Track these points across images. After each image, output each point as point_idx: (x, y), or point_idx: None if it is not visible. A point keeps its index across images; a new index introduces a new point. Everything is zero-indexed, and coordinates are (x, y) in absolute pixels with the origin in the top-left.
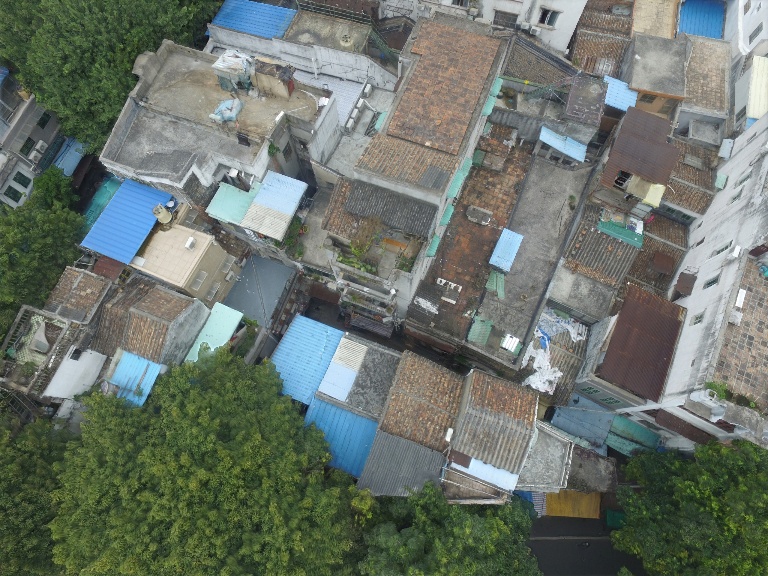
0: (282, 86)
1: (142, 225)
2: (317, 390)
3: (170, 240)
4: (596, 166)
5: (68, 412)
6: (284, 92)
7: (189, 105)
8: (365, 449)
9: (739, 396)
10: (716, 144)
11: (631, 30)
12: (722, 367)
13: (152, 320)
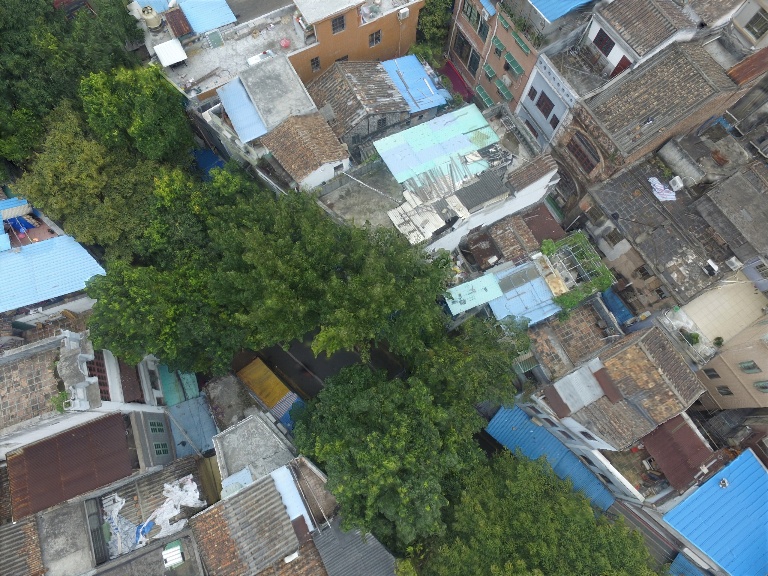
0: None
1: None
2: None
3: None
4: None
5: None
6: None
7: None
8: None
9: (56, 377)
10: None
11: None
12: (38, 405)
13: None
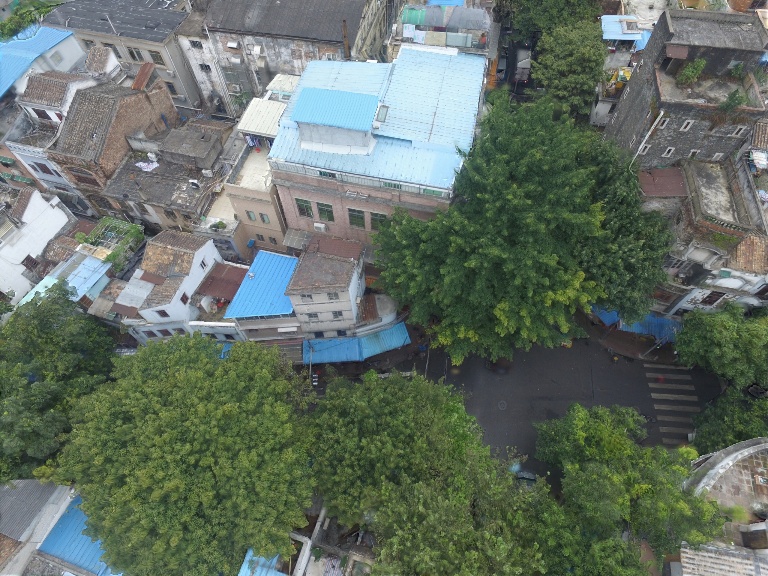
0: None
1: None
2: None
3: None
4: None
5: None
6: None
7: None
8: (63, 522)
9: None
10: None
11: None
12: None
13: None
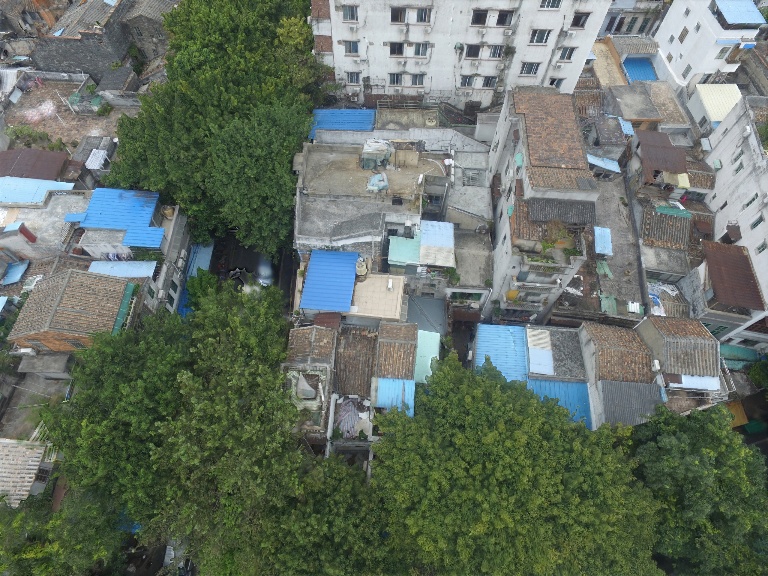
0: (416, 156)
1: (345, 280)
2: (529, 372)
3: (370, 287)
4: (626, 175)
5: (328, 454)
6: (415, 161)
7: (343, 185)
8: (585, 407)
9: None
10: (691, 145)
11: (600, 85)
12: None
13: (400, 344)
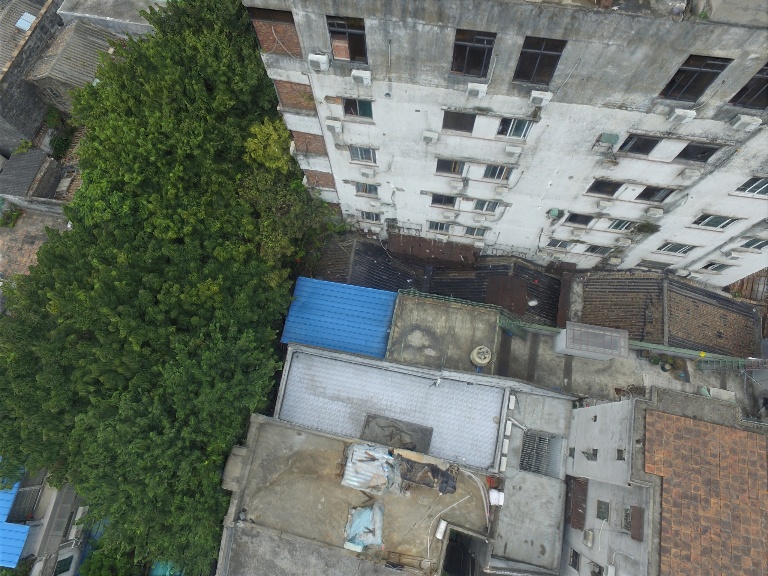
0: None
1: None
2: None
3: None
4: None
5: None
6: None
7: (306, 516)
8: None
9: None
10: None
11: None
12: None
13: None
